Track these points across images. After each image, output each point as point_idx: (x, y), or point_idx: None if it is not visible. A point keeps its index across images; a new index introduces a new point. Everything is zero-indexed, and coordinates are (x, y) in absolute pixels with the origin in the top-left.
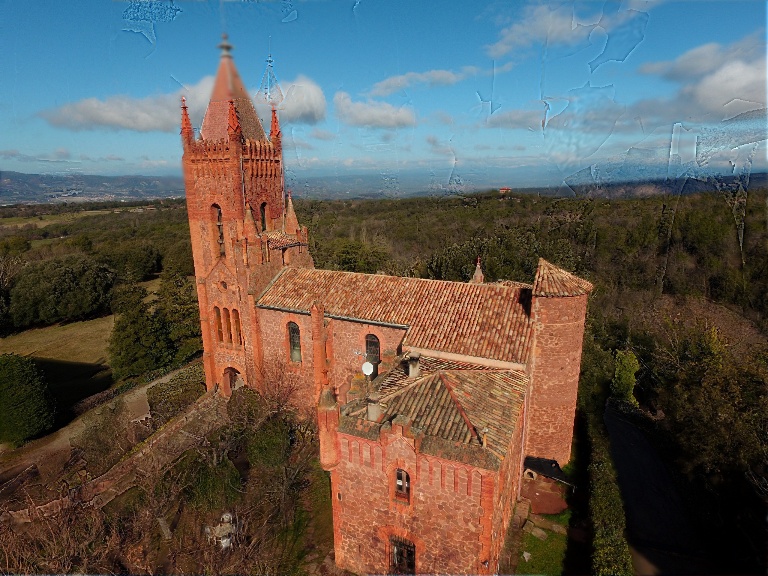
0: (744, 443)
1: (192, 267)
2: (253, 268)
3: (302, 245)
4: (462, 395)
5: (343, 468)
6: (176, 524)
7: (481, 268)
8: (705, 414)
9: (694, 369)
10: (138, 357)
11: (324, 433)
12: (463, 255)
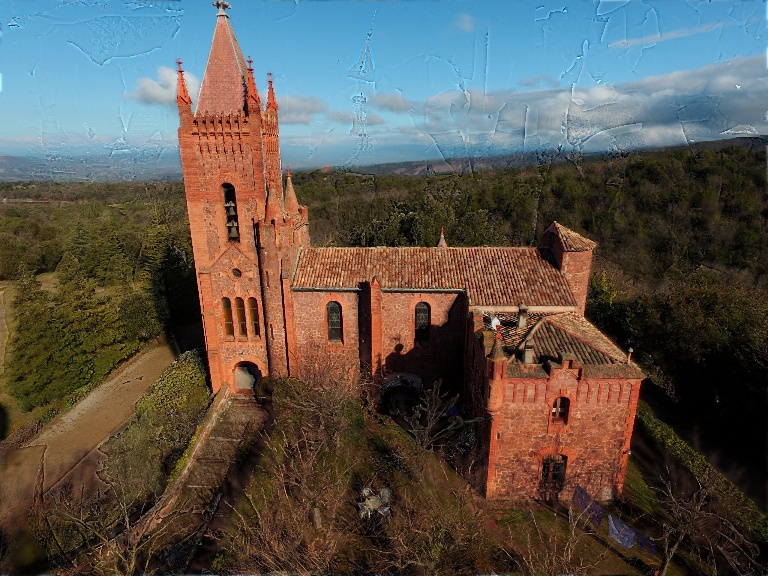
0: (715, 338)
1: (5, 269)
2: (284, 250)
3: (305, 225)
4: (573, 333)
5: (505, 410)
6: (312, 514)
7: (416, 240)
8: (689, 323)
9: (593, 305)
10: (56, 378)
11: (498, 381)
12: (394, 229)
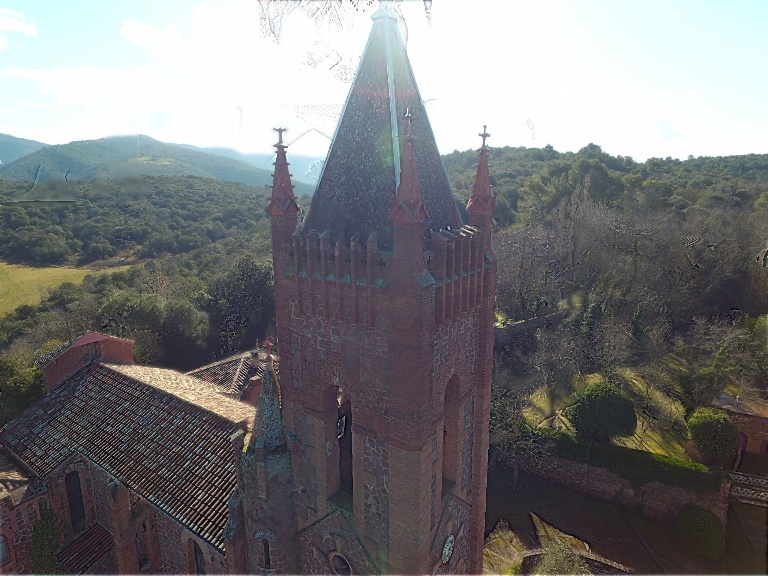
0: None
1: None
2: None
3: None
4: None
5: None
6: None
7: None
8: None
9: None
10: None
11: None
12: None
